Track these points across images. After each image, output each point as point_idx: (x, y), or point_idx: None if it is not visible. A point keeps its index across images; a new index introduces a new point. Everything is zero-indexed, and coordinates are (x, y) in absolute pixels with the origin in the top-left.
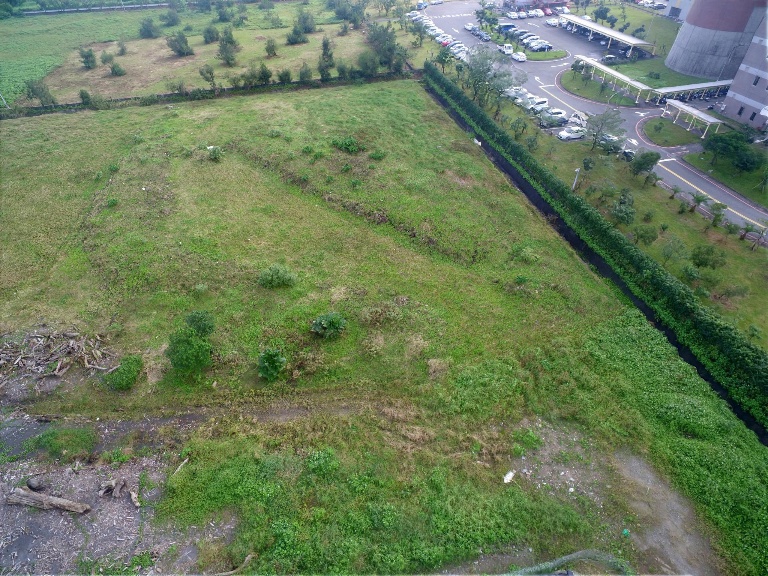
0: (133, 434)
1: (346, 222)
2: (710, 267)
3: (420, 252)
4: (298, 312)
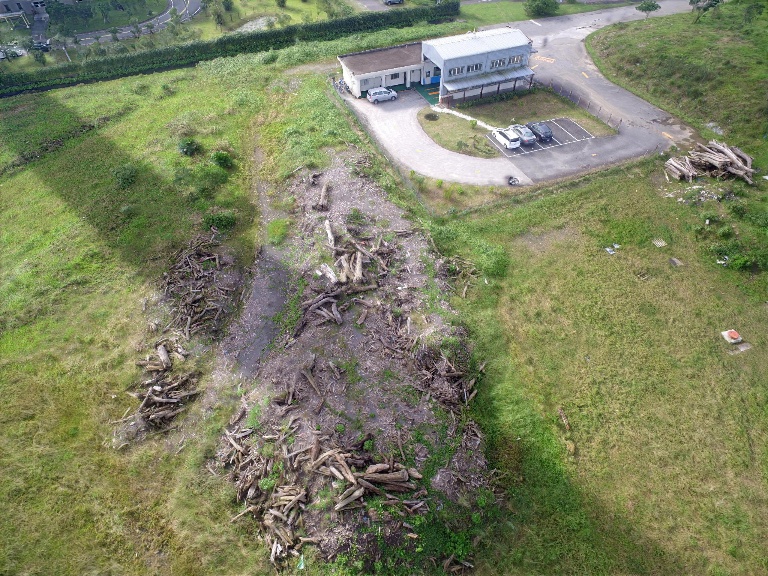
0: (273, 203)
1: (48, 163)
2: (180, 34)
3: (114, 125)
4: (171, 161)
